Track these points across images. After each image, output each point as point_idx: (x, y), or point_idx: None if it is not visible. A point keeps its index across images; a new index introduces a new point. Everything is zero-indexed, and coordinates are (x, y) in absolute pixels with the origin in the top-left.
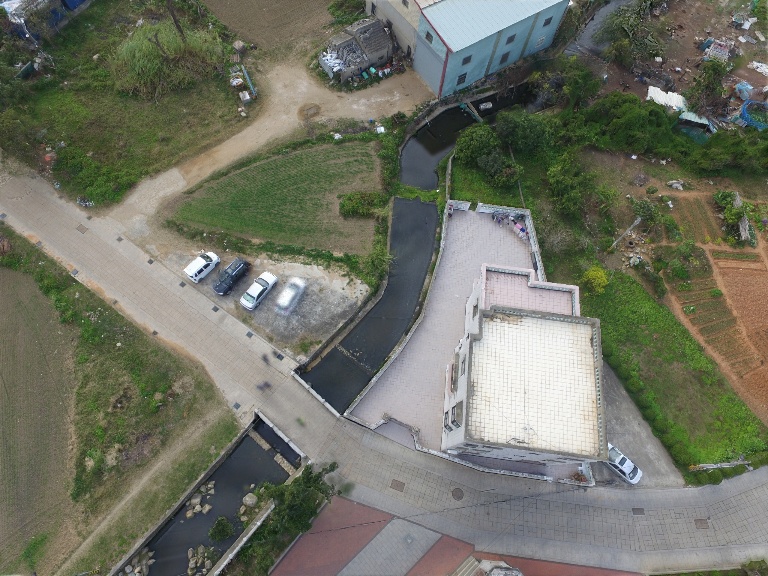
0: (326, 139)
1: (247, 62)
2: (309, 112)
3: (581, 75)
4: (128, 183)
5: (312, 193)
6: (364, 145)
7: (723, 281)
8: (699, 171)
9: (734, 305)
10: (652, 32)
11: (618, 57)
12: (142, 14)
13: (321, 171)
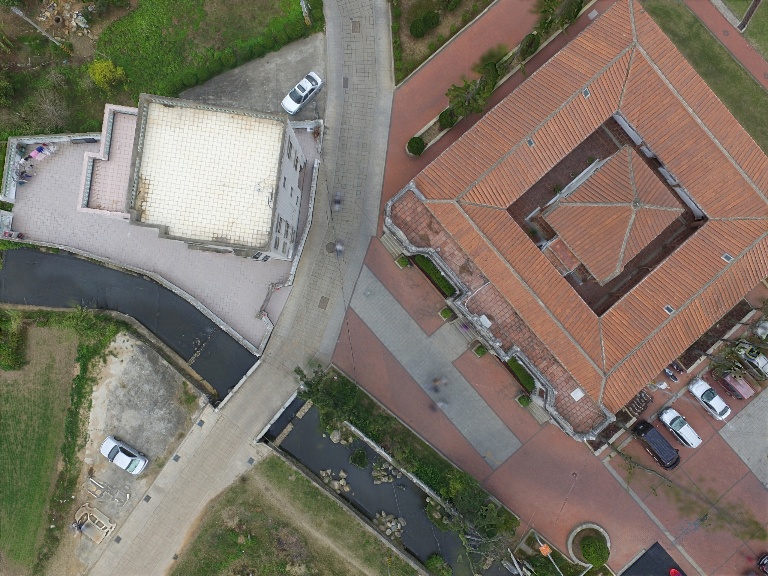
0: None
1: None
2: None
3: None
4: None
5: None
6: None
7: None
8: None
9: None
10: None
11: None
12: None
13: None
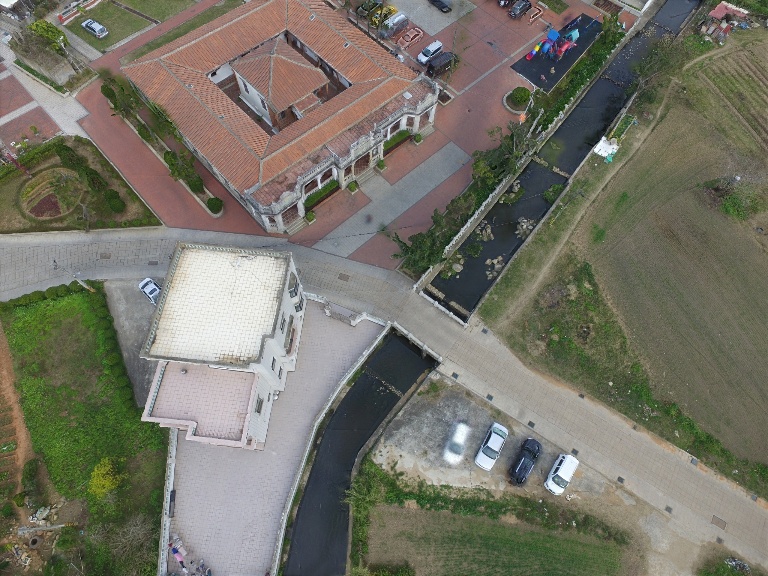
0: None
1: None
2: None
3: None
4: None
5: None
6: None
7: None
8: None
9: None
10: None
11: None
12: None
13: None
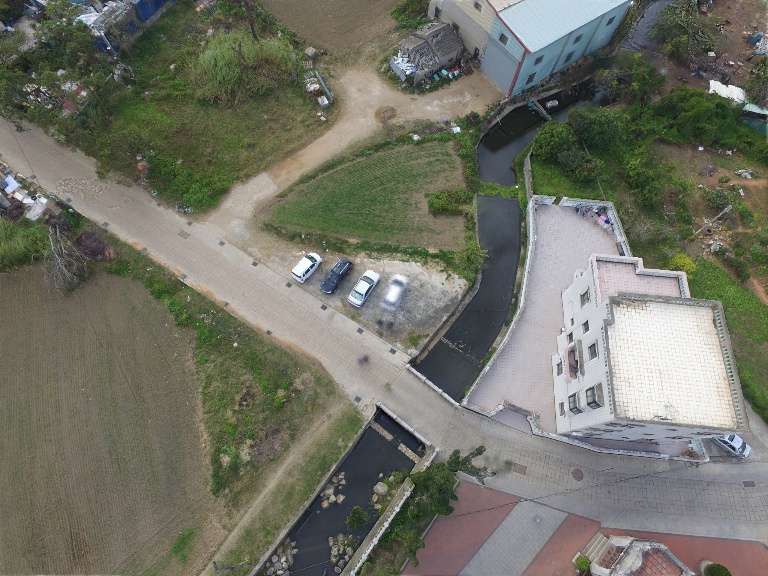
0: (406, 140)
1: (319, 68)
2: (386, 115)
3: (646, 71)
4: (222, 189)
5: (400, 193)
6: (443, 145)
7: None
8: (765, 160)
9: None
10: (702, 28)
11: (675, 53)
12: (211, 24)
13: (405, 171)
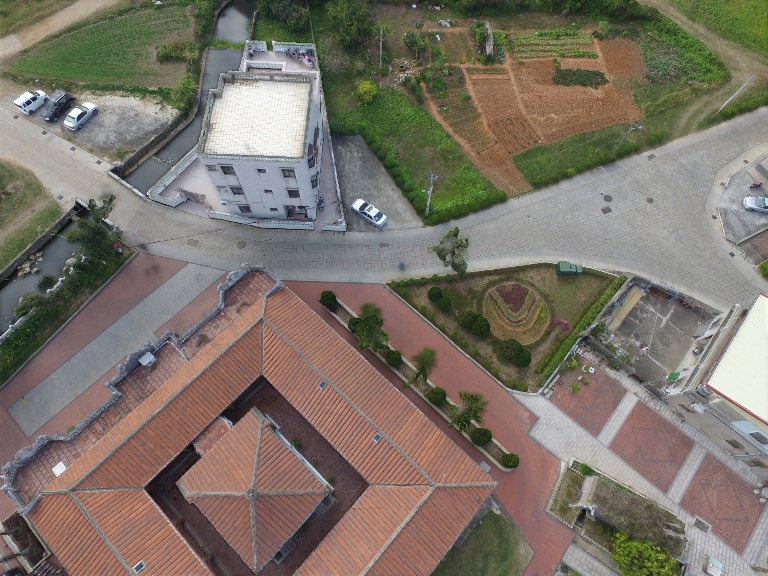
0: (148, 6)
1: None
2: None
3: None
4: None
5: (134, 46)
6: (182, 9)
7: (473, 89)
8: (465, 12)
9: (480, 105)
10: None
11: None
12: None
13: (142, 30)
